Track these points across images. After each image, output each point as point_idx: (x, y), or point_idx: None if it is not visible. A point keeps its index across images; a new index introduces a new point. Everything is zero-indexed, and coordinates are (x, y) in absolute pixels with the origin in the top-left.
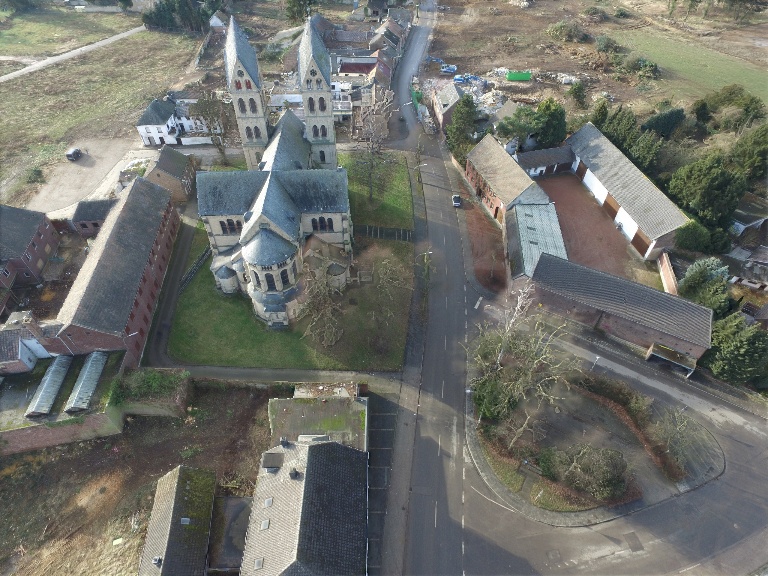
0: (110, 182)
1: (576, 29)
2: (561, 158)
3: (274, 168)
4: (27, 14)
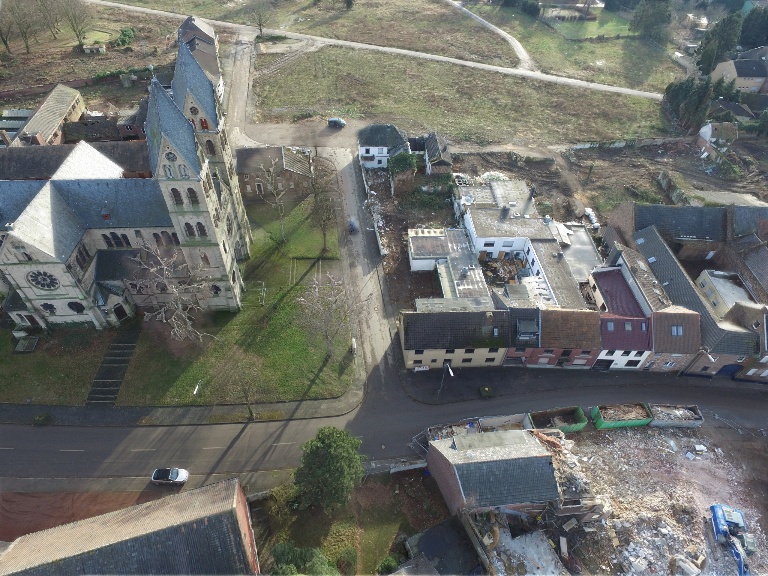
0: None
1: None
2: None
3: (59, 183)
4: (638, 41)
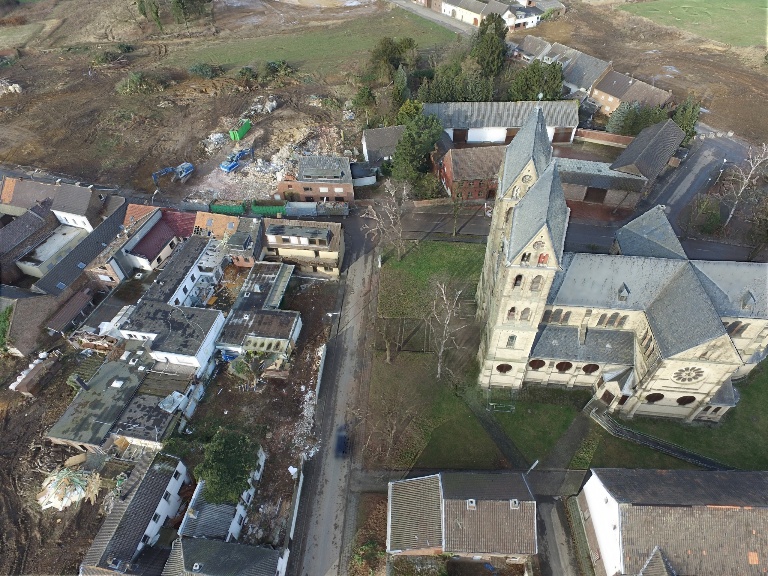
0: None
1: (158, 73)
2: (447, 138)
3: None
4: None
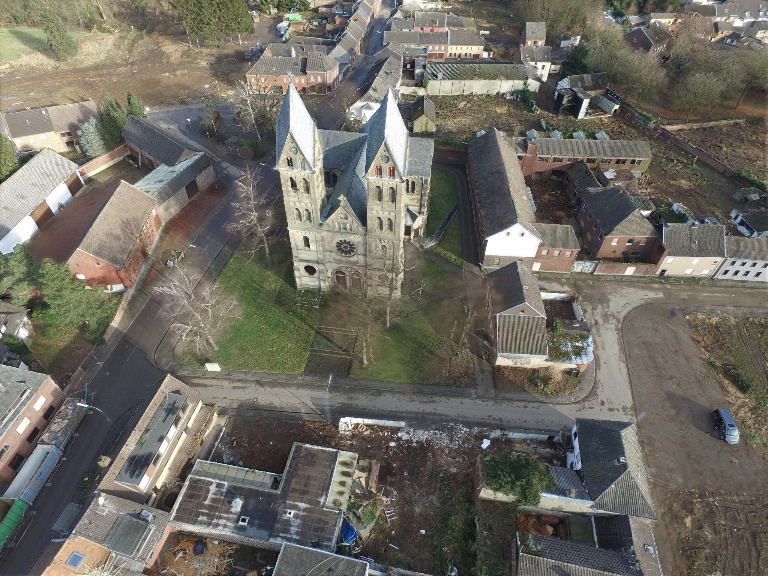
0: (609, 348)
1: None
2: None
3: None
4: None
